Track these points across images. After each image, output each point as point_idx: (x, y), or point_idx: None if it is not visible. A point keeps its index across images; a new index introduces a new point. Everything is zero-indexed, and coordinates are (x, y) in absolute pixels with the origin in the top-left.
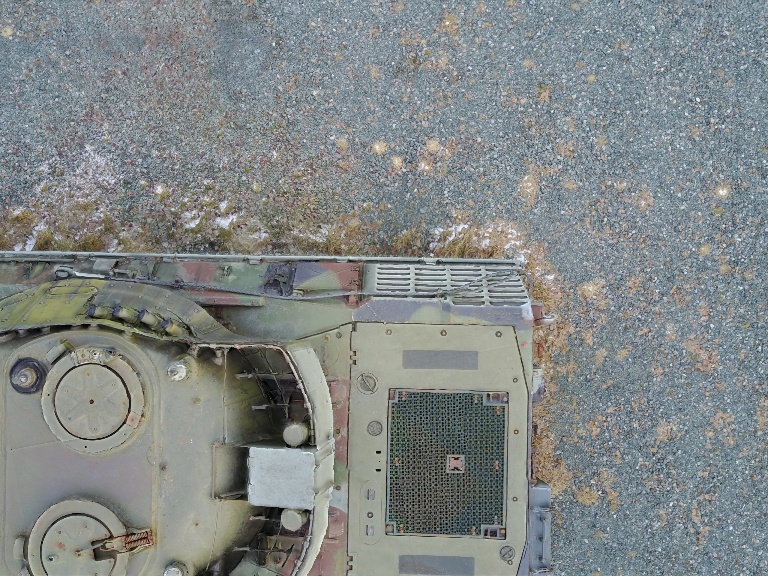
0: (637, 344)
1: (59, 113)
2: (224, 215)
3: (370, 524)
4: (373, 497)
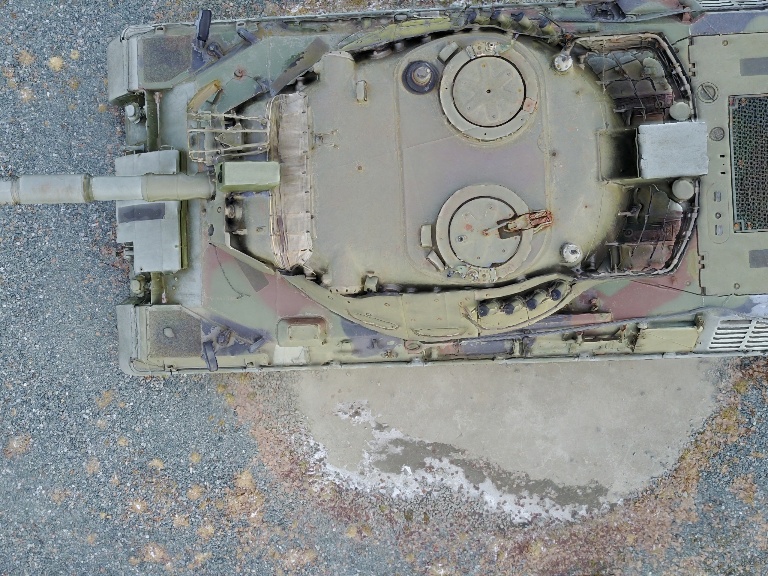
0: None
1: None
2: (491, 3)
3: (718, 224)
4: (719, 199)
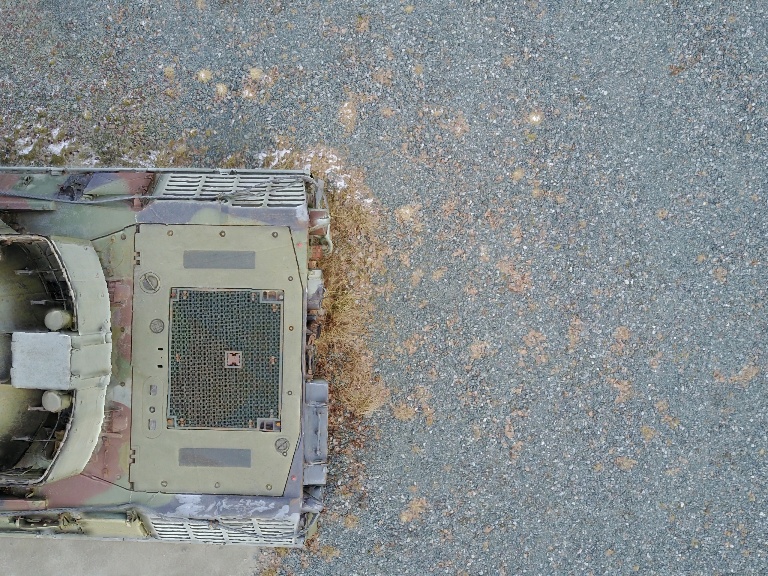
0: (452, 265)
1: None
2: (56, 142)
3: (152, 418)
4: (155, 392)
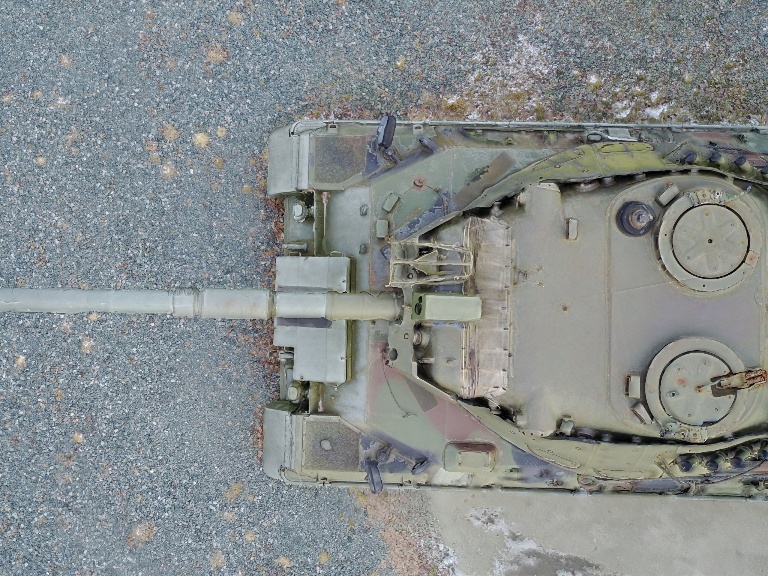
0: None
1: (492, 3)
2: (655, 105)
3: None
4: None
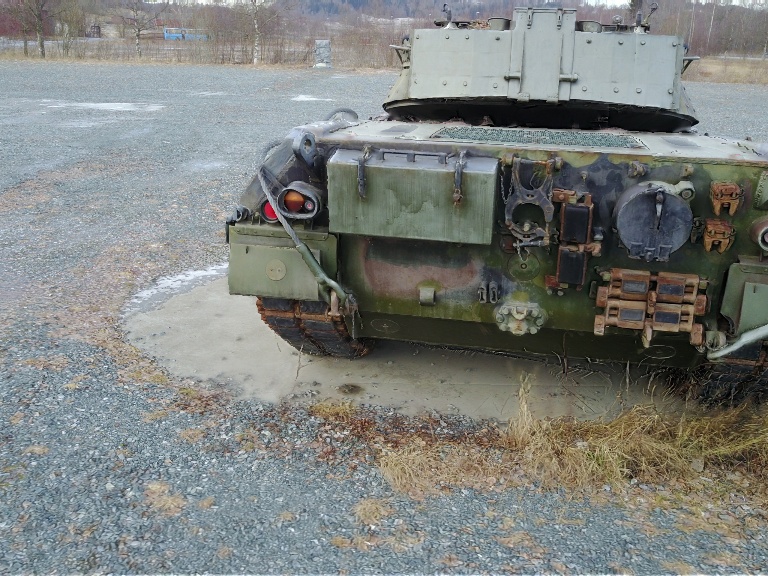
0: None
1: None
2: None
3: None
4: None
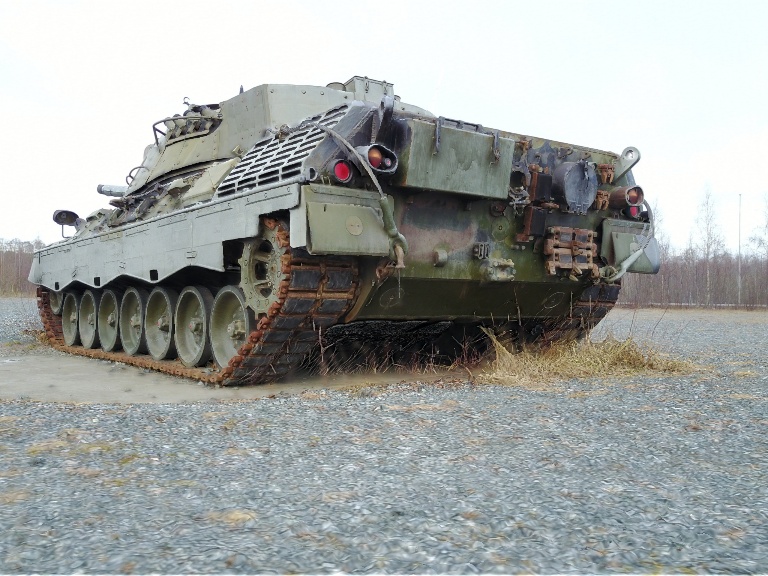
0: None
1: None
2: None
3: None
4: None
